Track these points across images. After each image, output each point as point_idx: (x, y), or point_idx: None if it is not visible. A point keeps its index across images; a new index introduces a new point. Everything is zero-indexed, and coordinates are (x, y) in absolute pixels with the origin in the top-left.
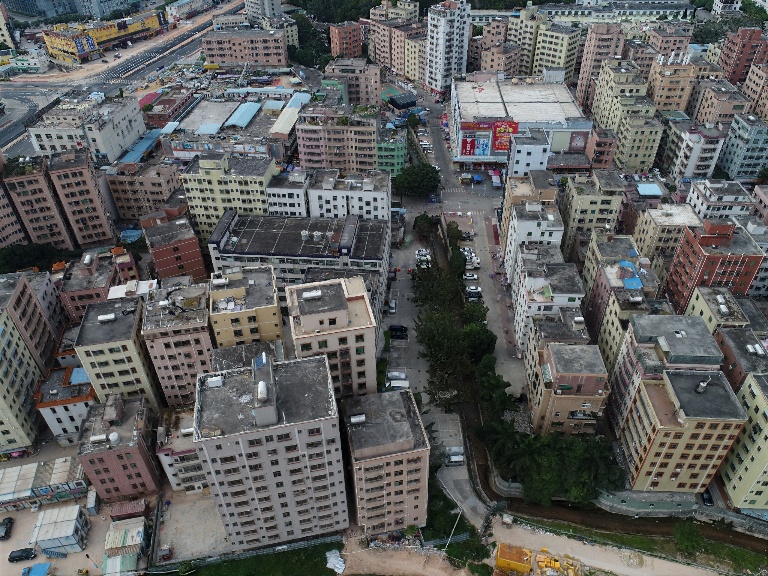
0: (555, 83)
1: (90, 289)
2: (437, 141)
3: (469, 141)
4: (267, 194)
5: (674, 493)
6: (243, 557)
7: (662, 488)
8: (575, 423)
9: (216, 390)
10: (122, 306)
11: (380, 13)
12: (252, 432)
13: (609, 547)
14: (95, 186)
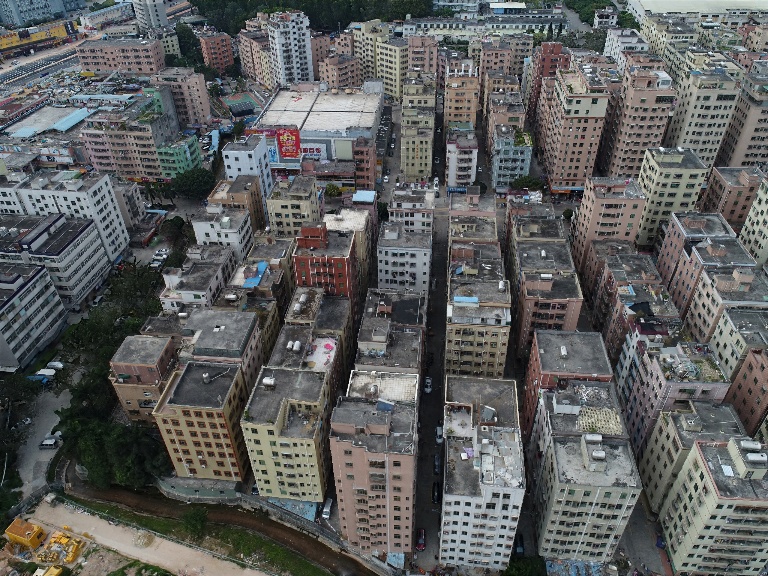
0: (374, 94)
1: None
2: None
3: None
4: None
5: (219, 481)
6: None
7: (203, 475)
8: (148, 412)
9: None
10: None
11: (254, 25)
12: None
13: (130, 528)
14: None
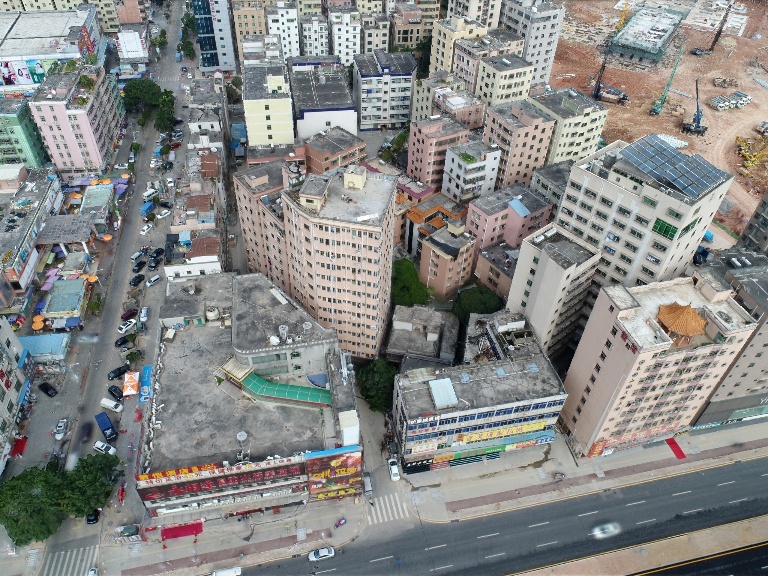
0: None
1: (456, 119)
2: None
3: None
4: None
5: None
6: None
7: None
8: None
9: None
10: None
11: None
12: None
13: None
14: None
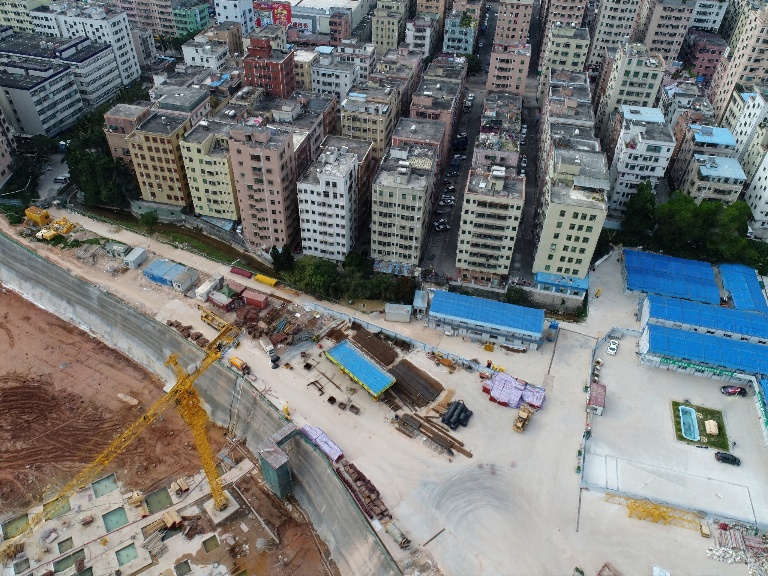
0: None
1: None
2: None
3: (256, 19)
4: (31, 16)
5: (171, 206)
6: None
7: (160, 199)
8: (129, 159)
9: None
10: None
11: None
12: None
13: (107, 223)
14: None
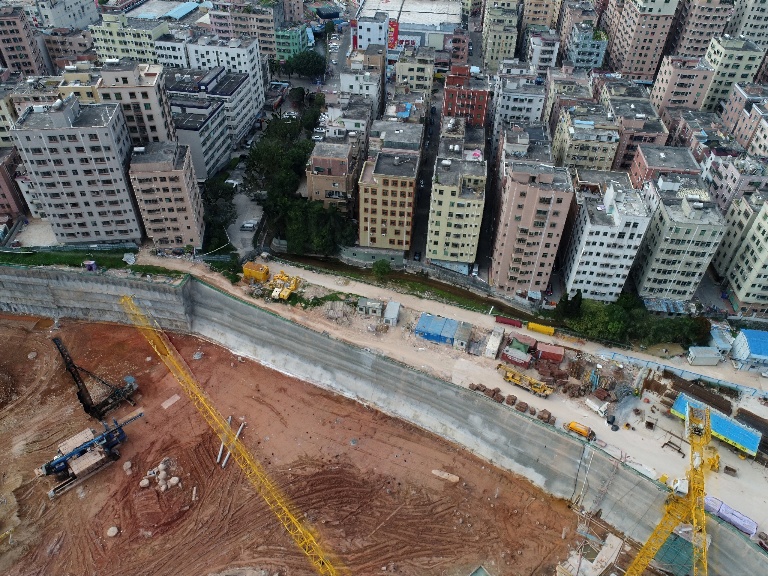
0: (454, 1)
1: None
2: (345, 44)
3: None
4: (155, 46)
5: (390, 250)
6: (67, 250)
7: (380, 244)
8: (331, 201)
9: (39, 114)
10: (6, 86)
11: None
12: (49, 129)
13: (330, 275)
14: (28, 37)
